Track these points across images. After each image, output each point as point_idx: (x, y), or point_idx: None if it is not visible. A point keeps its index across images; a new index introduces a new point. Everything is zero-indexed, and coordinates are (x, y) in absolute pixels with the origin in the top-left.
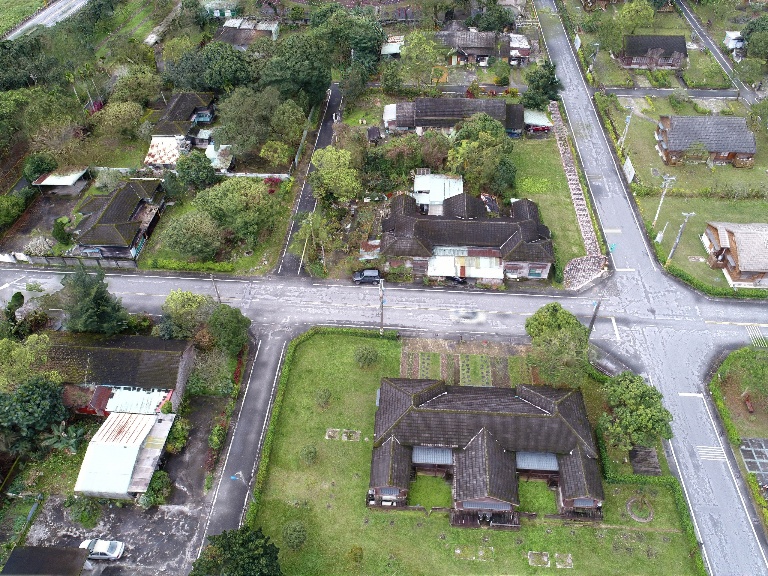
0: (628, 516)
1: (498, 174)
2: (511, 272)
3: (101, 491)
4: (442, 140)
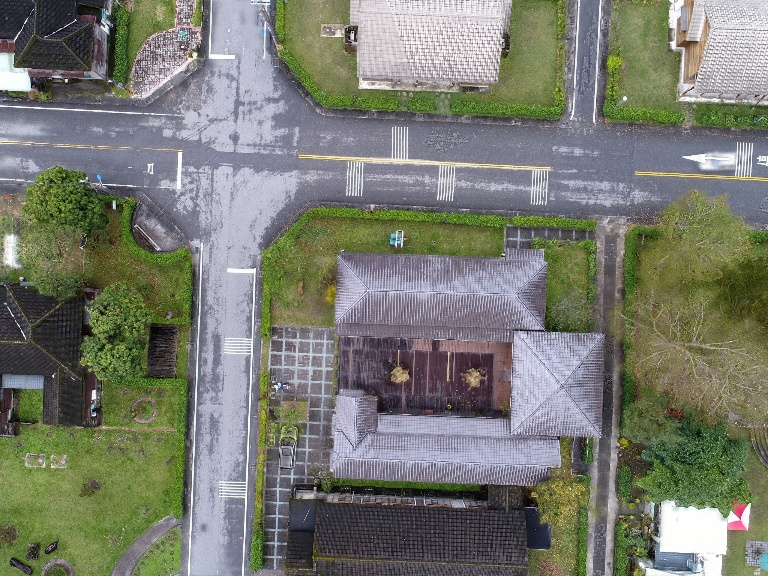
0: (129, 418)
1: None
2: None
3: None
4: None
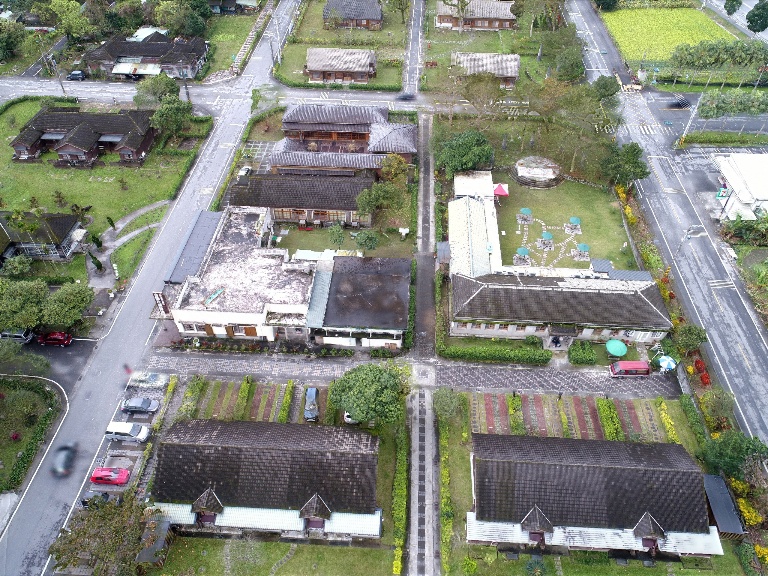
0: (158, 166)
1: (185, 23)
2: (168, 73)
3: None
4: (156, 4)
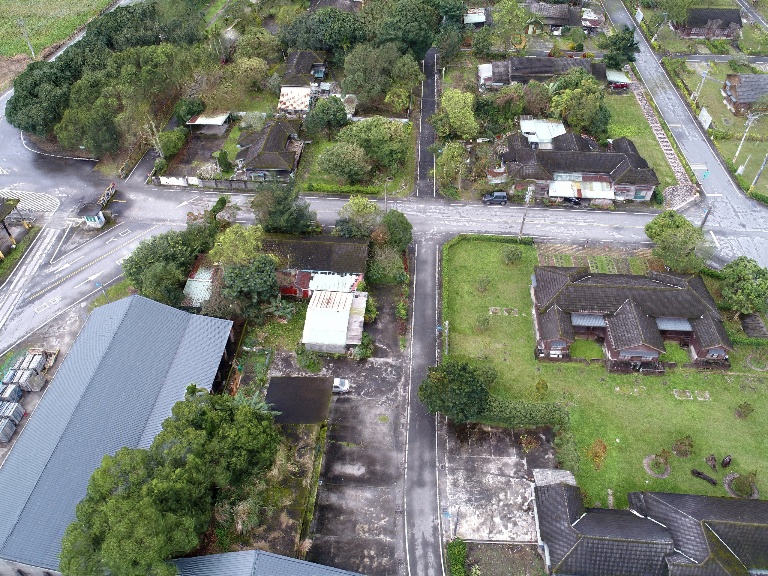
0: (749, 367)
1: (597, 117)
2: (619, 195)
3: (325, 343)
4: (544, 89)
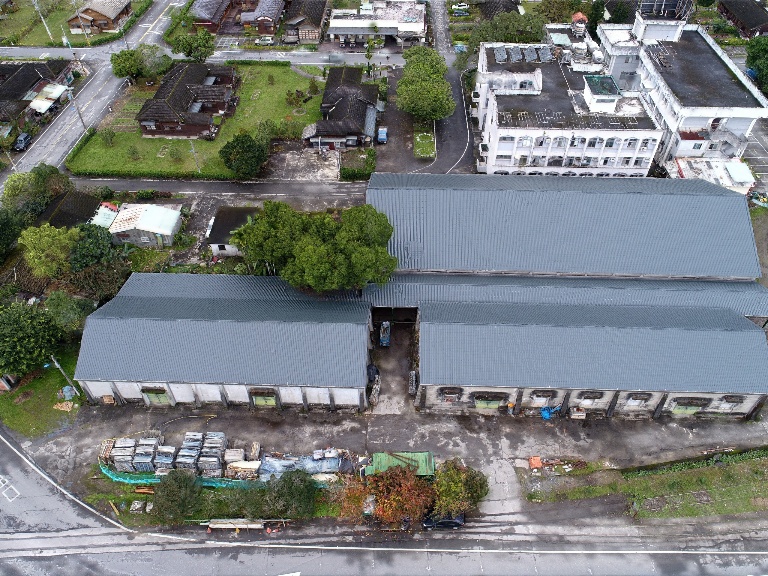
0: (241, 75)
1: None
2: None
3: (175, 222)
4: None
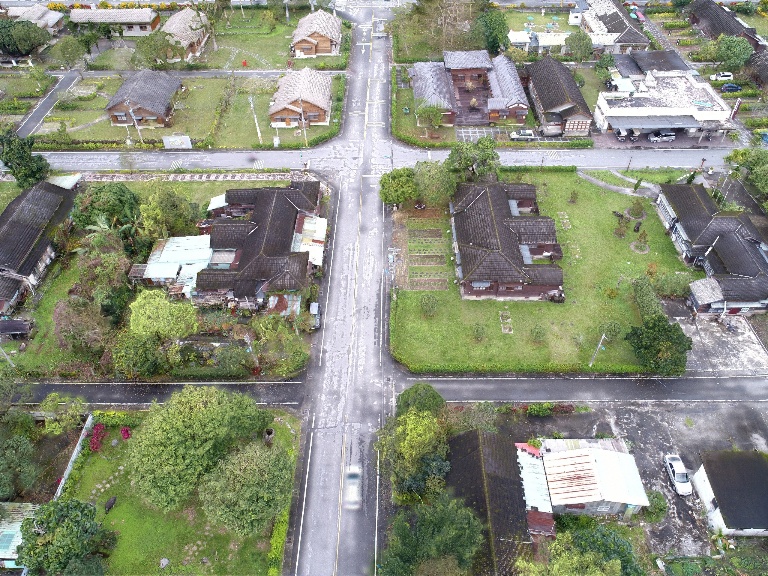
0: None
1: None
2: None
3: None
4: None
